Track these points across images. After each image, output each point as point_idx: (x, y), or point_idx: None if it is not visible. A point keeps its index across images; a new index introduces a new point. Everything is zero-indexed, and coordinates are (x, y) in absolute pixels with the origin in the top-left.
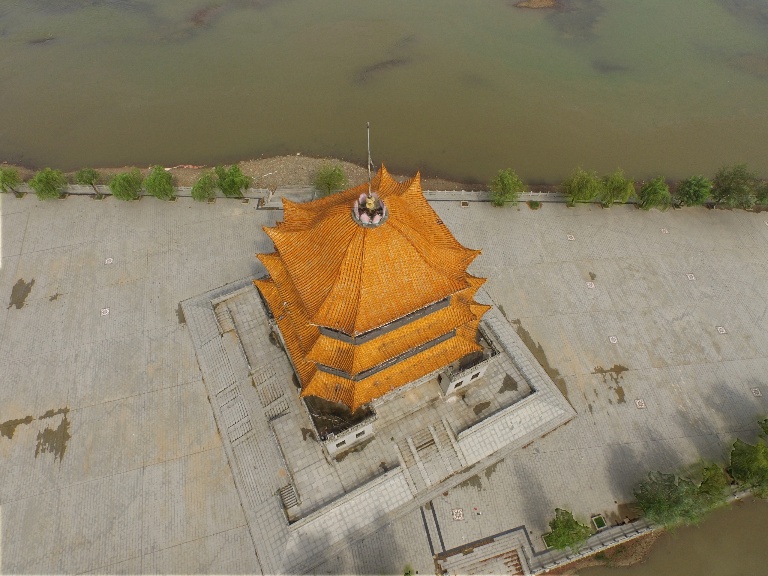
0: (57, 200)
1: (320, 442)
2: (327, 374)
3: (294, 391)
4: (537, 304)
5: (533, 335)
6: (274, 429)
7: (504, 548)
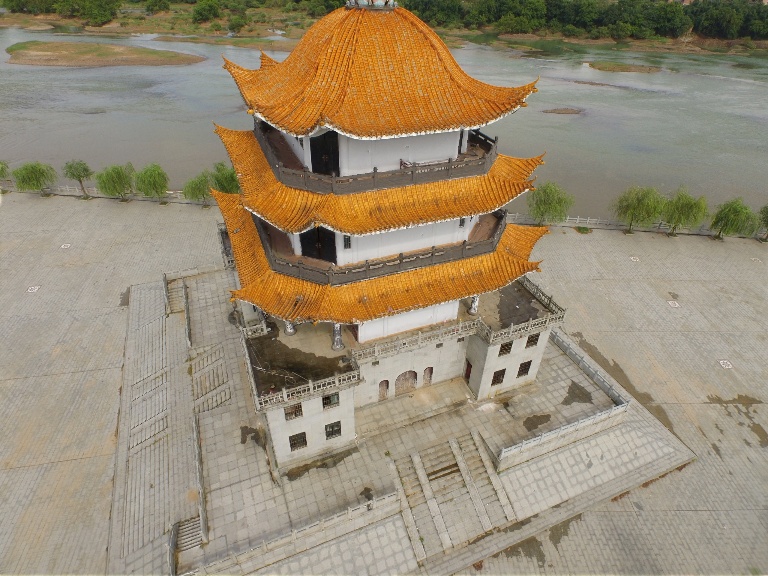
0: (39, 198)
1: (254, 395)
2: (285, 279)
3: (245, 378)
4: (603, 318)
5: (603, 351)
6: (198, 424)
7: None
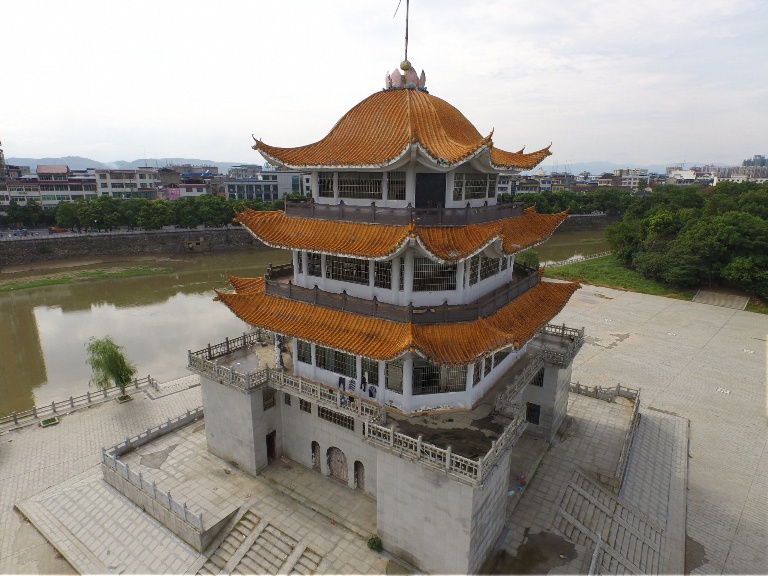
0: None
1: None
2: None
3: None
4: None
5: None
6: None
7: (178, 386)
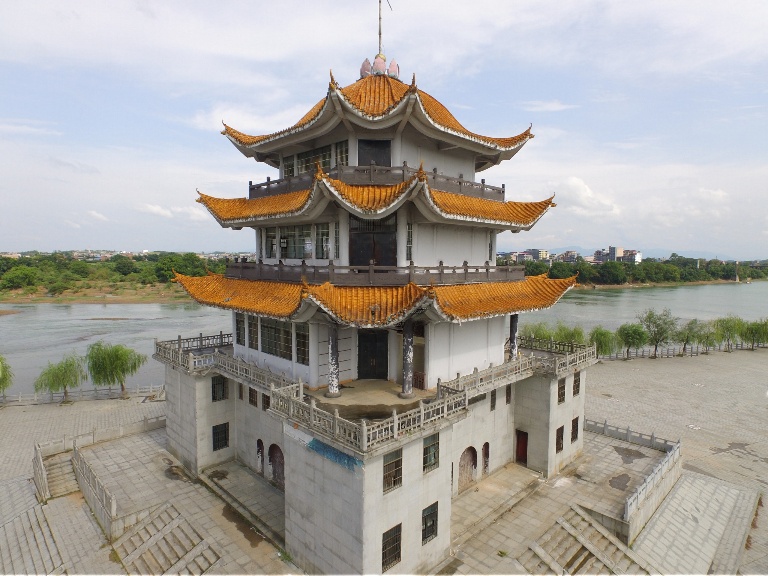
0: None
1: None
2: (347, 293)
3: (230, 529)
4: None
5: None
6: None
7: None
